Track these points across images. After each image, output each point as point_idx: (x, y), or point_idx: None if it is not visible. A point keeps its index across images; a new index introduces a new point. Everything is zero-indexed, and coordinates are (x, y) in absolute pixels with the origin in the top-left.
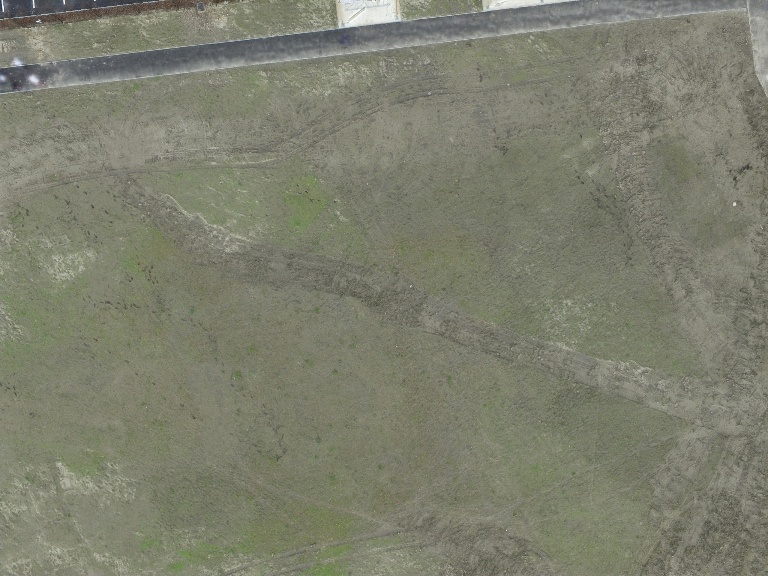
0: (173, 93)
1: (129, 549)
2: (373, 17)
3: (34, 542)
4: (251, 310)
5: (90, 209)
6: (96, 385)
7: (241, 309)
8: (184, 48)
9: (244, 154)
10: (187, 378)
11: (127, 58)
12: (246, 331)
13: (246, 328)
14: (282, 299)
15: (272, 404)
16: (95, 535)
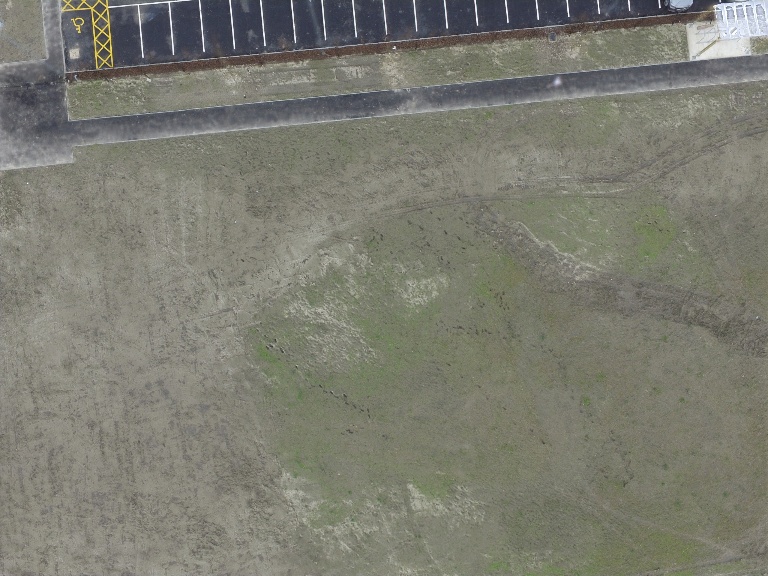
0: (525, 122)
1: (478, 571)
2: (724, 50)
3: (385, 562)
4: (600, 338)
5: (443, 235)
6: (448, 409)
7: (591, 337)
8: (536, 77)
9: (595, 184)
10: (537, 403)
11: (480, 86)
12: (595, 358)
13: (595, 355)
14: (631, 327)
15: (620, 431)
16: (445, 556)
